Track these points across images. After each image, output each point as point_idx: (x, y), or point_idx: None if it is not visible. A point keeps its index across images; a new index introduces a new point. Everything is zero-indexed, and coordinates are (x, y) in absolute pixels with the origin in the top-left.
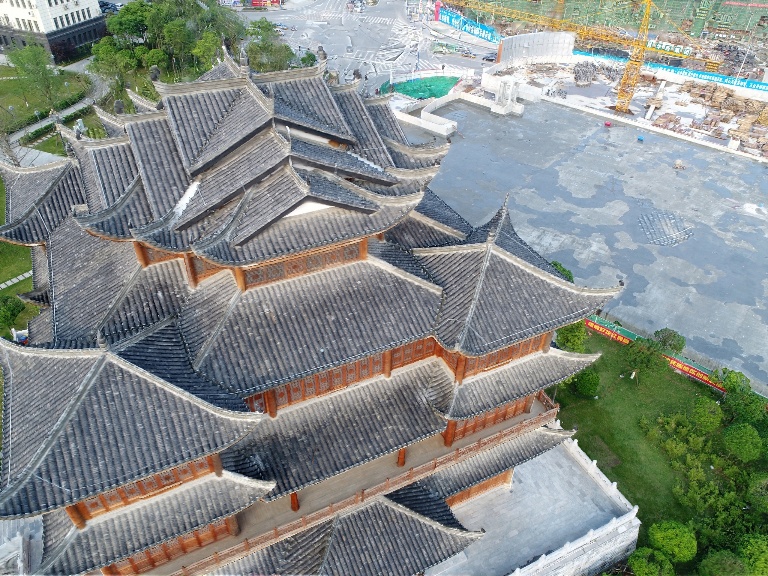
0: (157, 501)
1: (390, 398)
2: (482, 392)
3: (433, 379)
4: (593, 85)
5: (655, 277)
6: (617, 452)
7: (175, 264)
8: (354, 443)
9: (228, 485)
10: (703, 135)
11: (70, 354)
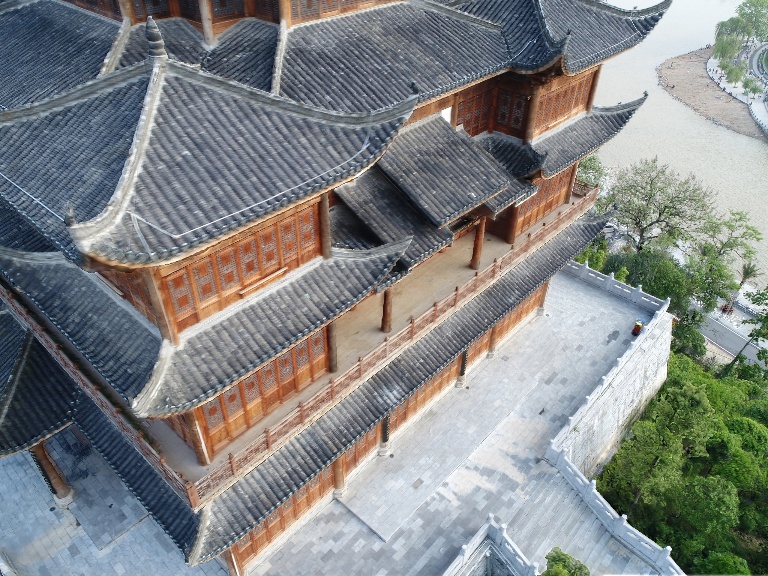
0: None
1: None
2: None
3: None
4: None
5: None
6: None
7: None
8: None
9: None
10: None
11: None
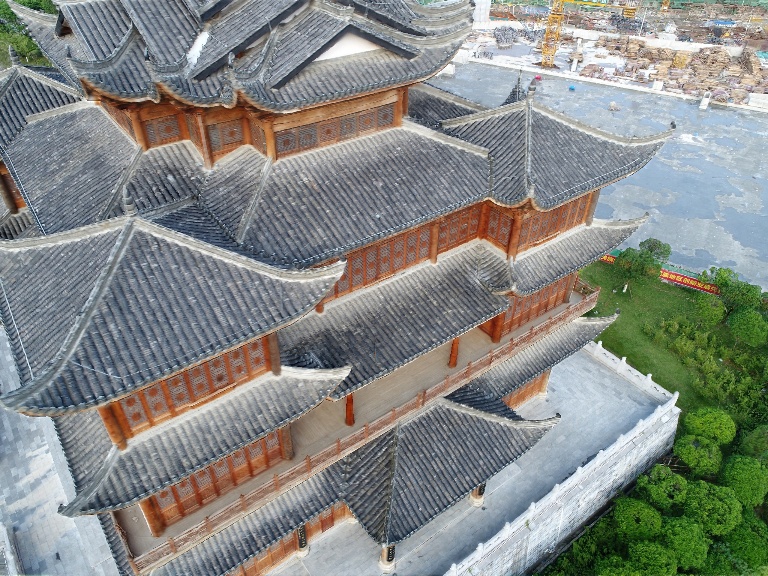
0: (209, 410)
1: (442, 283)
2: (536, 267)
3: (482, 261)
4: (515, 46)
5: (618, 204)
6: (629, 359)
7: (181, 146)
8: (416, 330)
9: (289, 383)
10: (627, 81)
11: (81, 234)
